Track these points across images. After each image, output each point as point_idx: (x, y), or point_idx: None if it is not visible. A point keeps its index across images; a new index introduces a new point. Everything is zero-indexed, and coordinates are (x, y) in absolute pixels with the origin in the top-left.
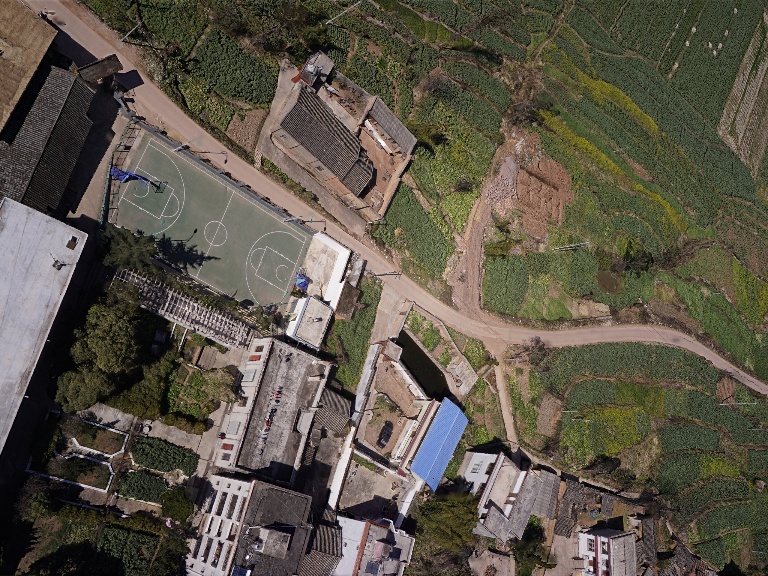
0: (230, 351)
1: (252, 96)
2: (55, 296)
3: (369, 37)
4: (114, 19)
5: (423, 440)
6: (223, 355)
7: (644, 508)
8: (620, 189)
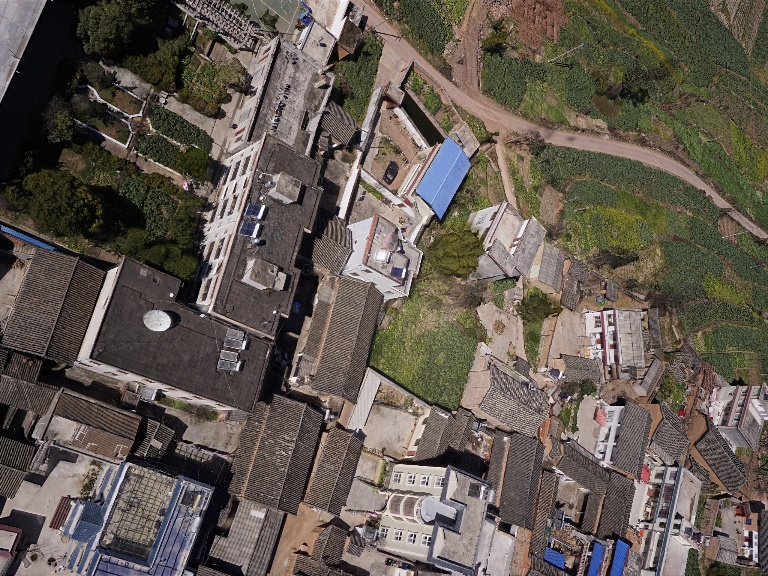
0: (239, 54)
1: None
2: None
3: None
4: None
5: None
6: (233, 56)
7: (649, 303)
8: (614, 29)
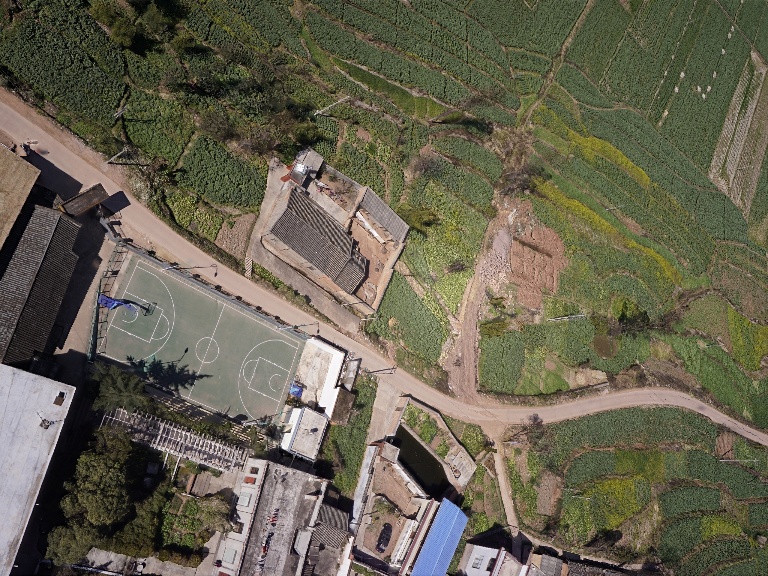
0: (224, 474)
1: (241, 201)
2: (43, 457)
3: (358, 122)
4: (99, 142)
5: (423, 545)
6: (217, 479)
7: None
8: (614, 248)
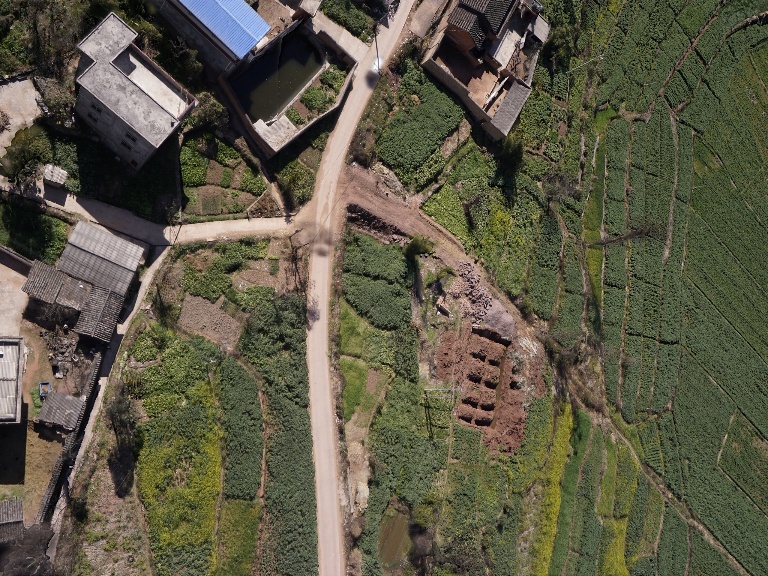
0: None
1: None
2: None
3: None
4: None
5: None
6: None
7: None
8: None
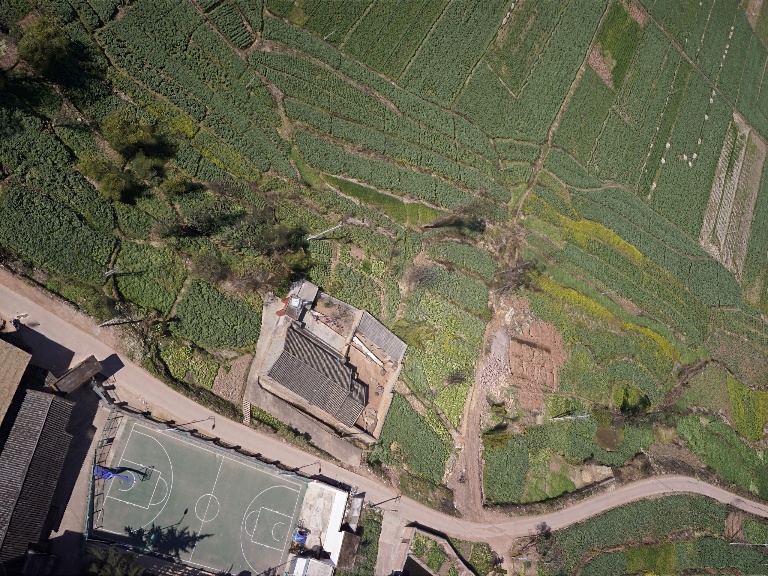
0: None
1: (237, 342)
2: None
3: (351, 240)
4: (90, 306)
5: None
6: None
7: None
8: (611, 333)
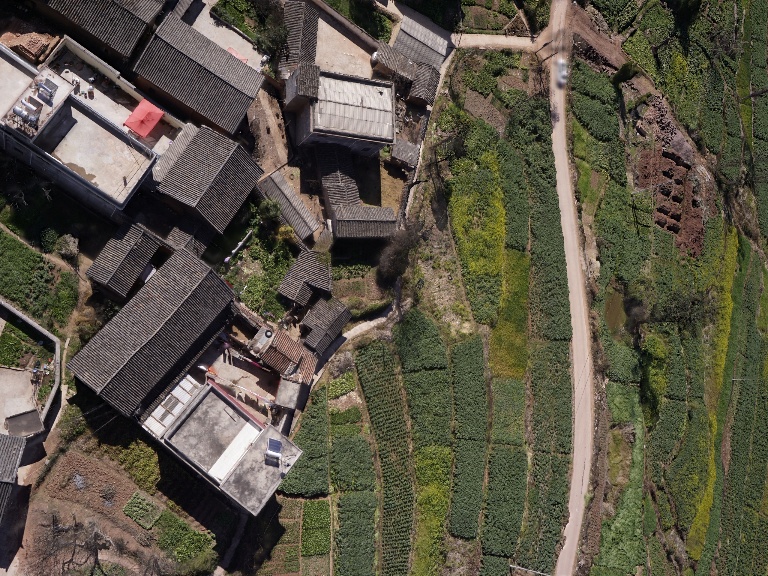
0: None
1: None
2: None
3: None
4: None
5: None
6: None
7: None
8: None
